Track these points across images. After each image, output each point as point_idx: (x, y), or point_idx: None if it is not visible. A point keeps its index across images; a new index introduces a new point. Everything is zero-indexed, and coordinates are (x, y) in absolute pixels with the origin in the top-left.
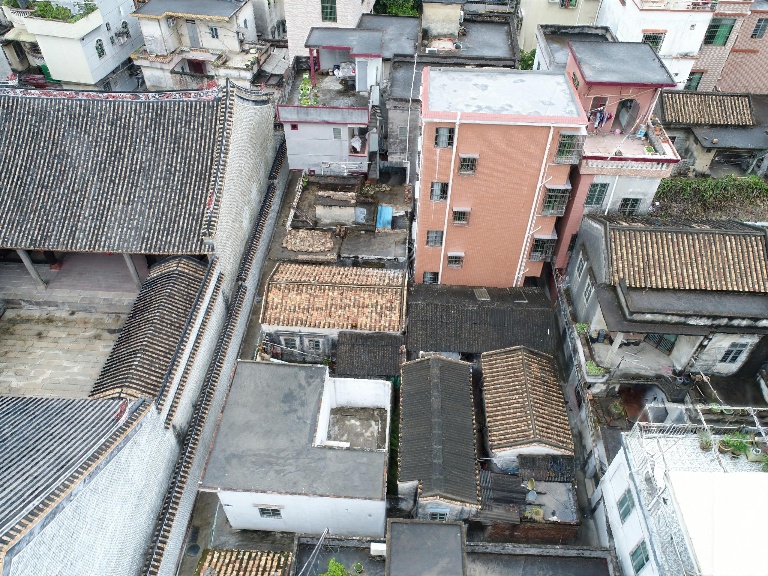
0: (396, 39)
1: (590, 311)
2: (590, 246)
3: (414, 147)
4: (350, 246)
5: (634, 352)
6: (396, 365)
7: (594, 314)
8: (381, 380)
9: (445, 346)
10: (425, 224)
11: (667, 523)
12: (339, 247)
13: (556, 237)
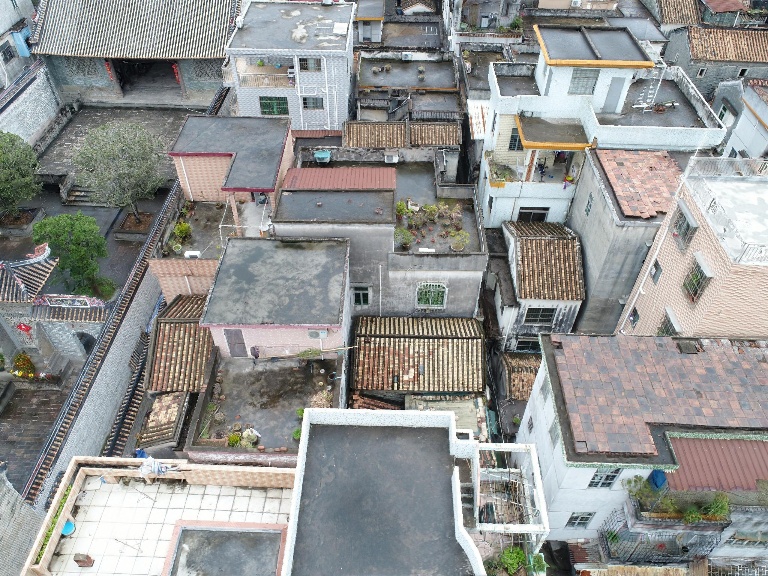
0: None
1: None
2: None
3: None
4: None
5: None
6: None
7: None
8: None
9: None
10: None
11: None
12: None
13: None
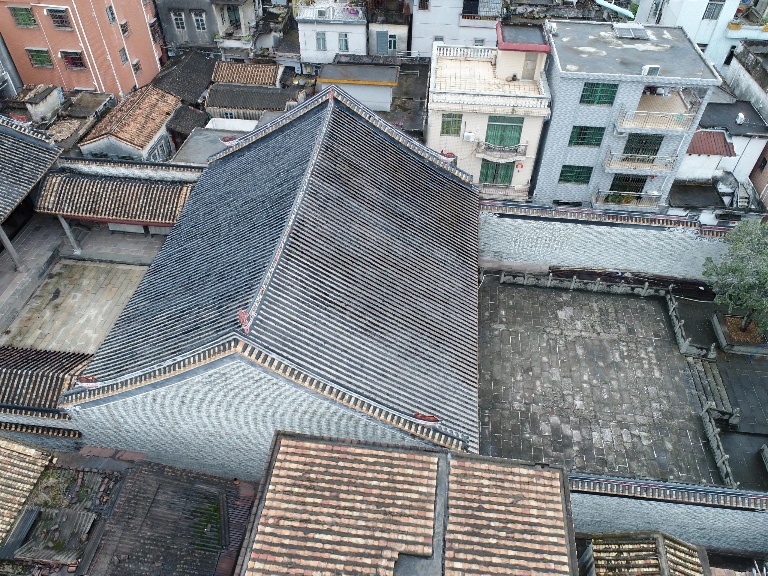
0: None
1: (212, 28)
2: (178, 2)
3: (1, 57)
4: (82, 114)
5: (237, 34)
6: (201, 115)
7: (217, 24)
8: (209, 121)
9: (199, 91)
10: (116, 47)
11: (342, 8)
12: (81, 116)
13: (156, 18)
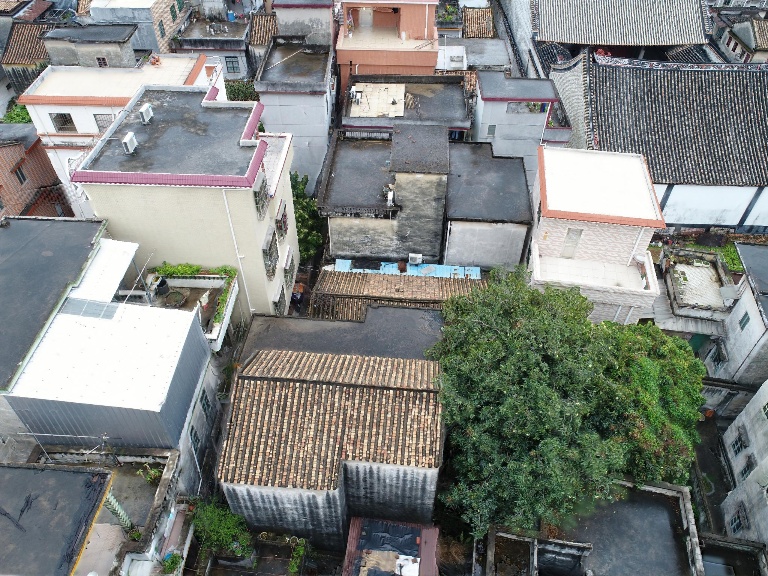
0: (474, 174)
1: None
2: None
3: None
4: None
5: None
6: None
7: None
8: None
9: None
10: None
11: None
12: None
13: None
